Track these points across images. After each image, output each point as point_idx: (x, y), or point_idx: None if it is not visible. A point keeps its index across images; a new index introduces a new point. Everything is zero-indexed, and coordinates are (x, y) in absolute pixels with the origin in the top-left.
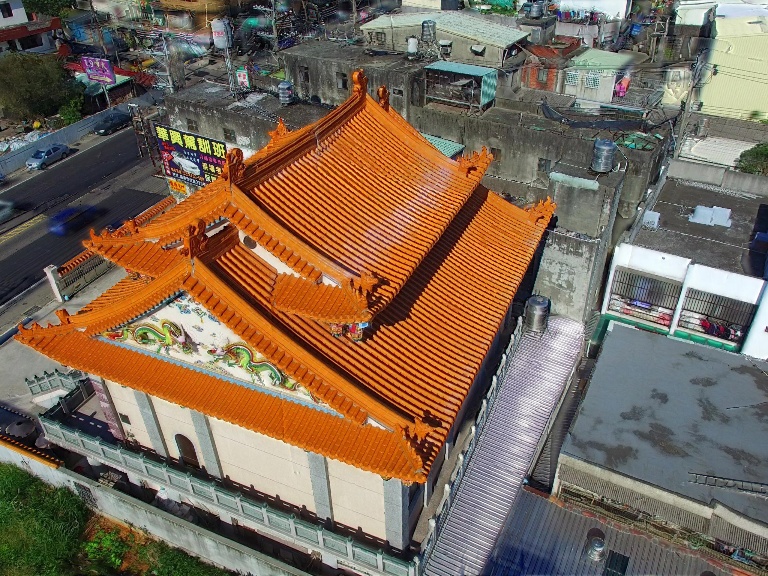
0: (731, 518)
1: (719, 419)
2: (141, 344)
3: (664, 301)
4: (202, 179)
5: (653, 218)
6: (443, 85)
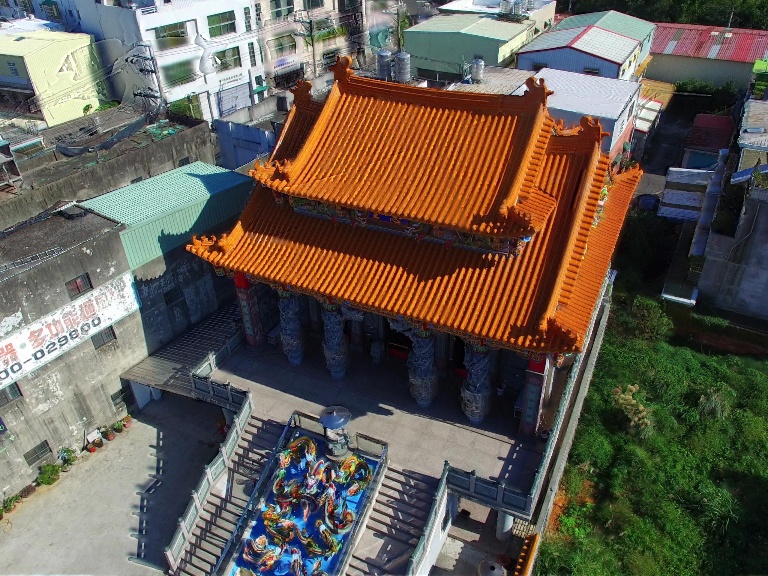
0: None
1: None
2: None
3: None
4: None
5: None
6: None
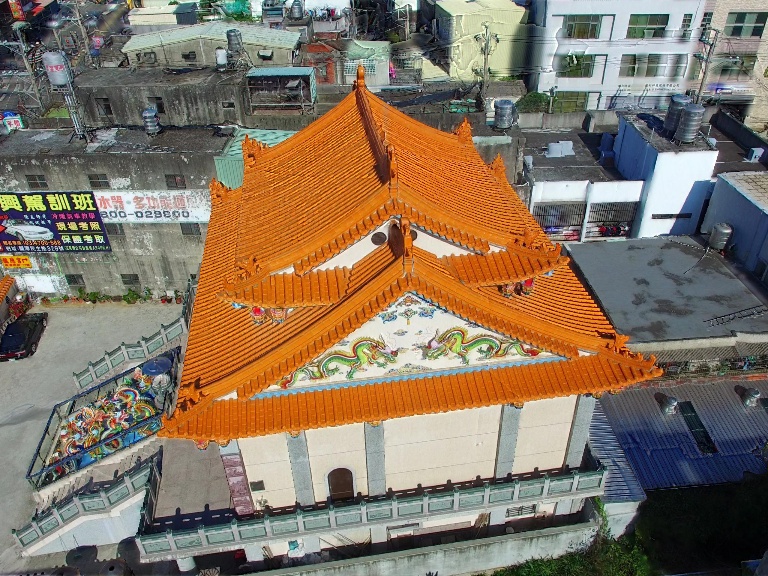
0: (747, 339)
1: (686, 282)
2: (314, 381)
3: (573, 220)
4: (57, 243)
5: (528, 161)
6: (268, 91)
